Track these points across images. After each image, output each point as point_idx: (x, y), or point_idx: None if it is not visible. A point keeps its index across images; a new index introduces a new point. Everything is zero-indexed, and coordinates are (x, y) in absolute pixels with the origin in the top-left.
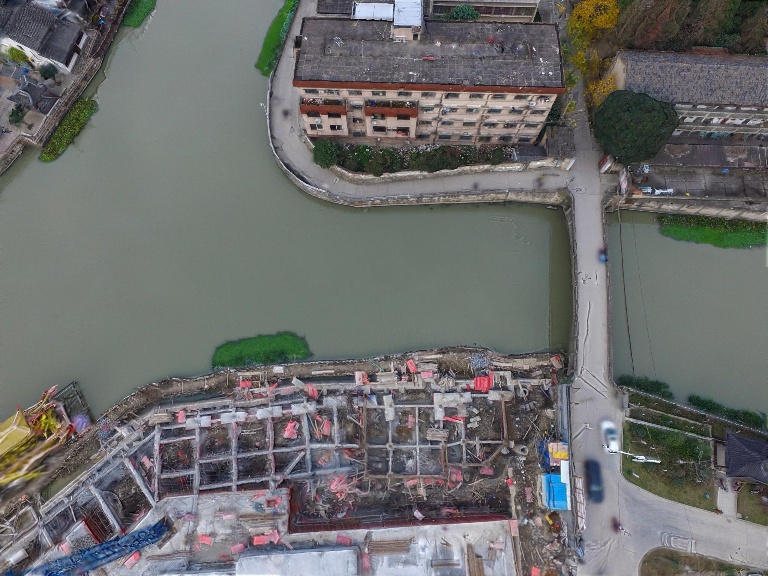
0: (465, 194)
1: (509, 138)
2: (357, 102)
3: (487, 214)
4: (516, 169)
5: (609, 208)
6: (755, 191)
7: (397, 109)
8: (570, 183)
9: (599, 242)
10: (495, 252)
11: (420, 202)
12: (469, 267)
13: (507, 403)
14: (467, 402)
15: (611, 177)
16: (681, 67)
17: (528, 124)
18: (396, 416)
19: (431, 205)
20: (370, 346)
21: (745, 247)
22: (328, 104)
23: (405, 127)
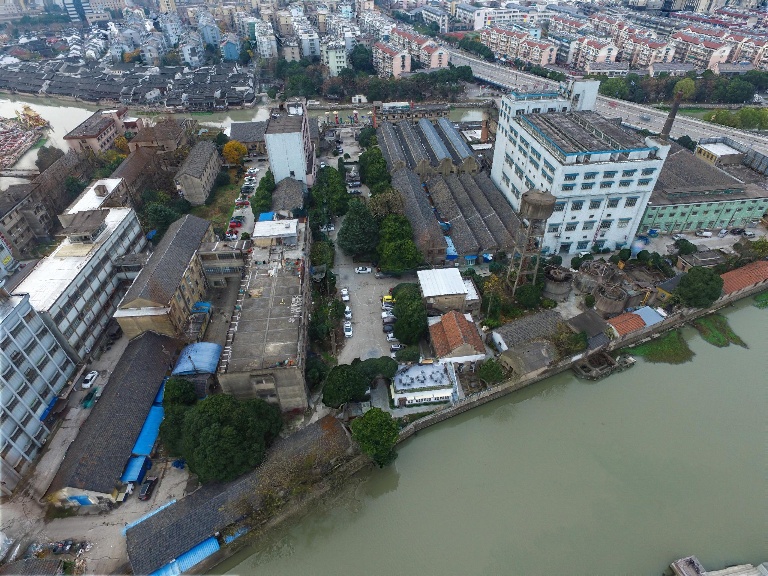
0: None
1: None
2: None
3: None
4: None
5: None
6: None
7: None
8: None
9: None
10: None
11: None
12: None
13: None
14: None
15: None
16: None
17: None
18: None
19: None
20: None
21: None
22: None
23: None
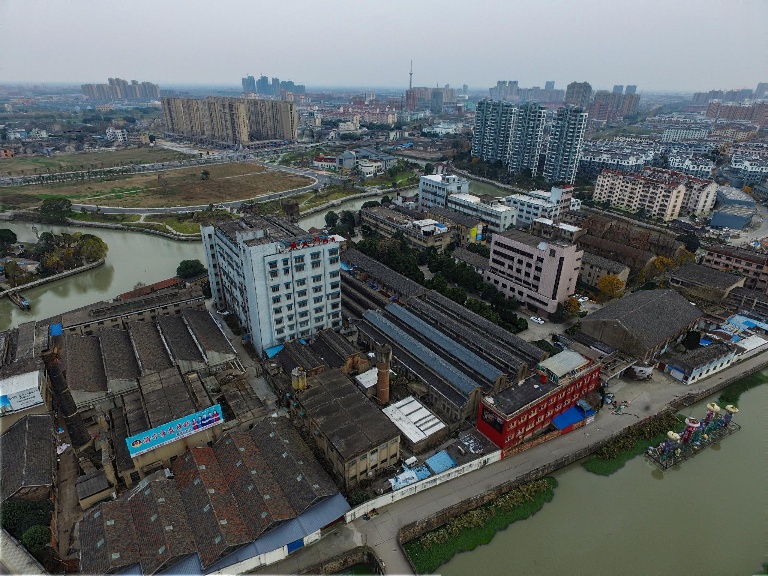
0: None
1: None
2: None
3: None
4: None
5: None
6: None
7: None
8: None
9: None
10: None
11: None
12: None
13: None
14: None
15: None
16: None
17: None
18: None
19: None
20: None
21: None
22: None
23: None
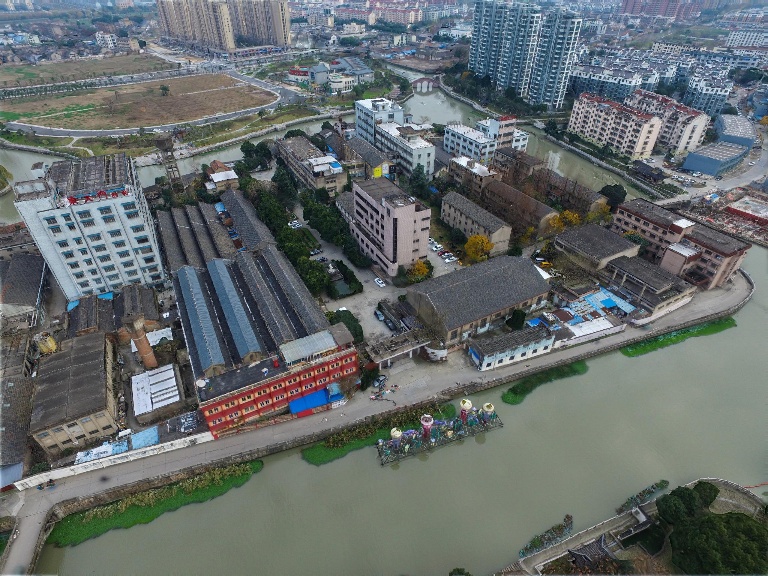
0: None
1: None
2: None
3: None
4: None
5: None
6: None
7: None
8: None
9: None
10: None
11: None
12: None
13: None
14: None
15: None
16: None
17: None
18: None
19: None
20: None
21: None
22: None
23: None
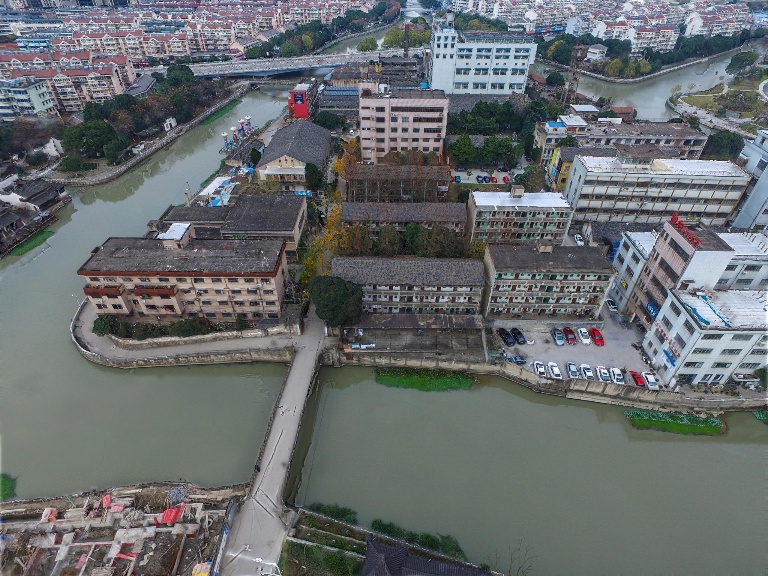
0: (214, 354)
1: (261, 315)
2: (131, 287)
3: (236, 372)
4: (260, 335)
5: (334, 363)
6: (445, 346)
7: (157, 290)
8: (299, 343)
9: (307, 384)
10: (235, 402)
11: (179, 363)
12: (206, 414)
13: (190, 537)
14: (148, 537)
15: (333, 339)
16: (368, 262)
17: (266, 302)
18: (68, 555)
19: (189, 366)
20: (80, 487)
21: (444, 390)
22: (106, 288)
23: (170, 305)
